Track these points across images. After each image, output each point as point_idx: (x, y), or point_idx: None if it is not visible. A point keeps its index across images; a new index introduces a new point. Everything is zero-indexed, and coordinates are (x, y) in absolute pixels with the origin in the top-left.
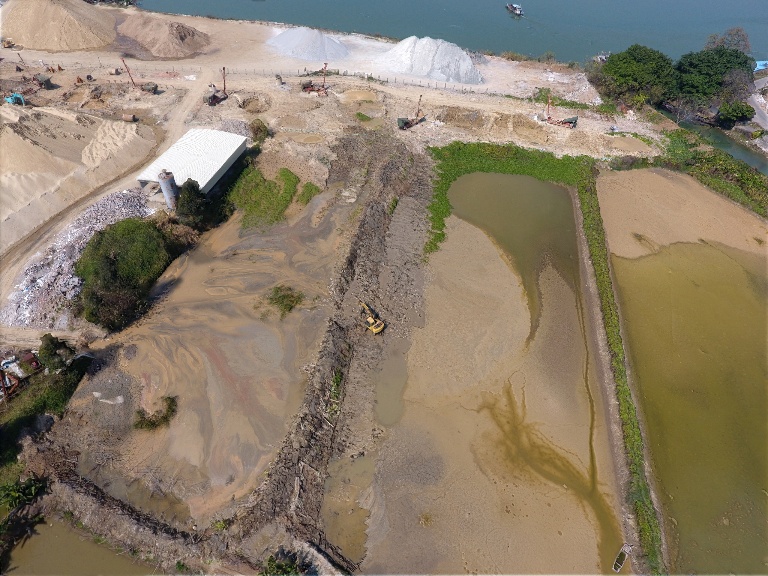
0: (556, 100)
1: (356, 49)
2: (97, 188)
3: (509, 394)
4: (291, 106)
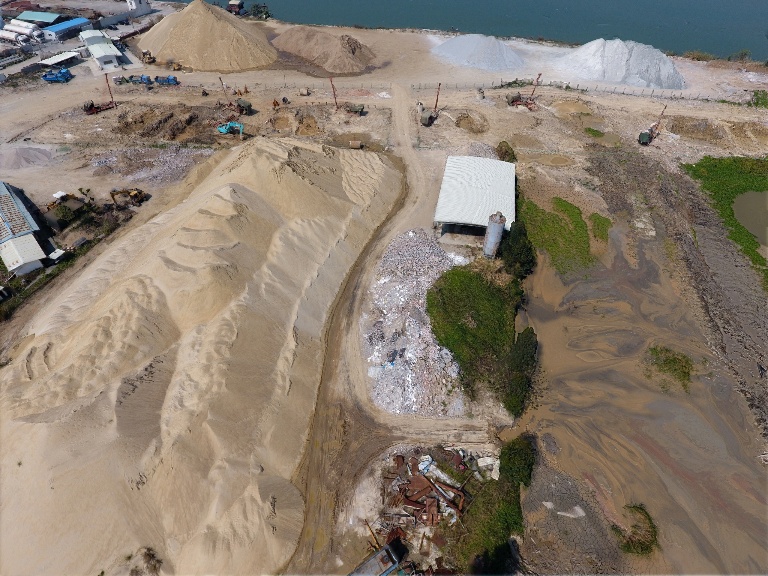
0: None
1: (527, 55)
2: (375, 230)
3: None
4: (510, 123)
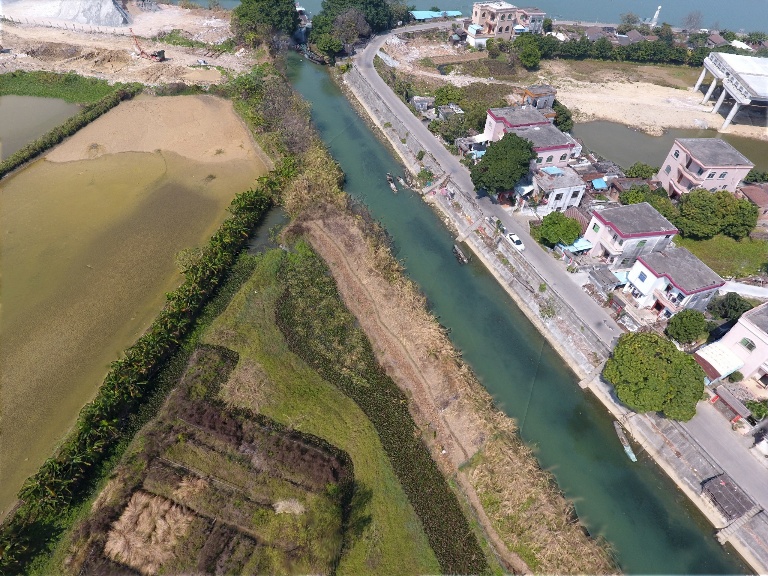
0: (180, 40)
1: None
2: None
3: None
4: None
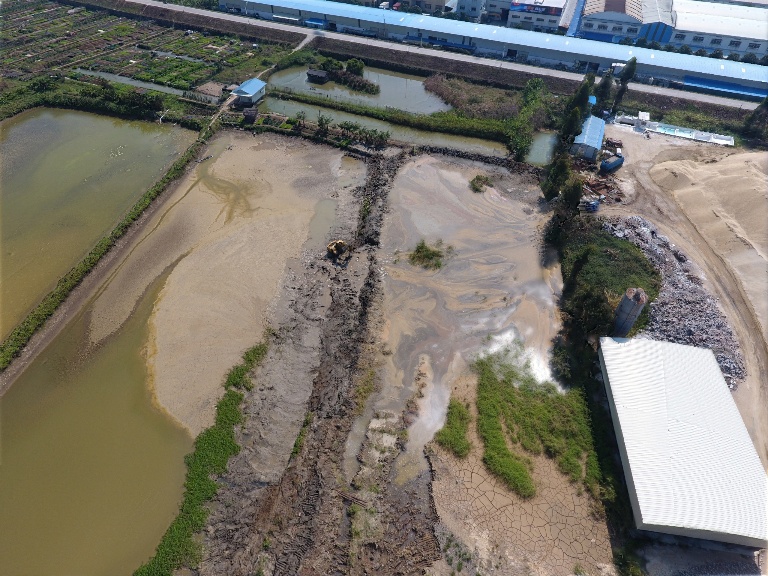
0: None
1: None
2: None
3: (229, 217)
4: None
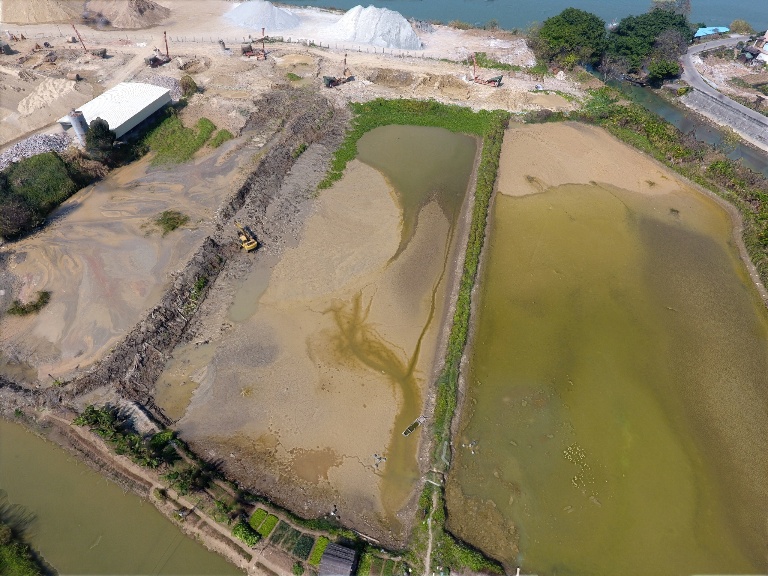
0: (490, 63)
1: (308, 20)
2: (28, 132)
3: (357, 301)
4: (228, 68)
